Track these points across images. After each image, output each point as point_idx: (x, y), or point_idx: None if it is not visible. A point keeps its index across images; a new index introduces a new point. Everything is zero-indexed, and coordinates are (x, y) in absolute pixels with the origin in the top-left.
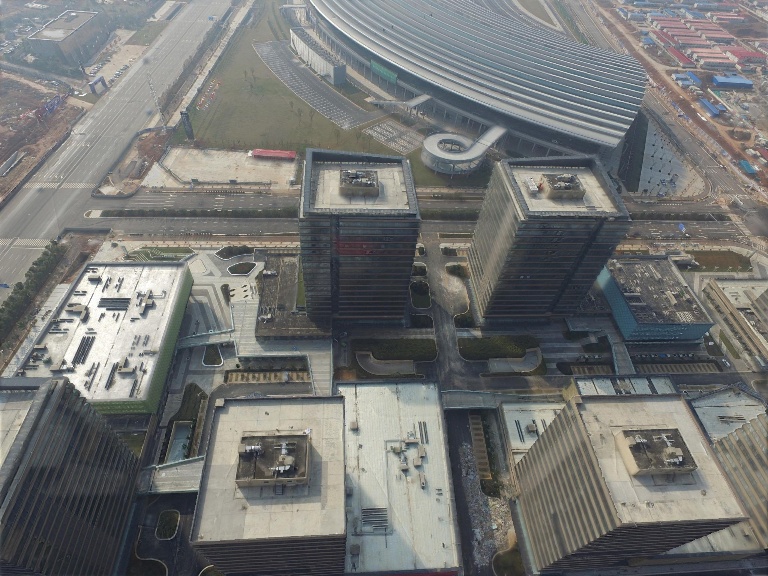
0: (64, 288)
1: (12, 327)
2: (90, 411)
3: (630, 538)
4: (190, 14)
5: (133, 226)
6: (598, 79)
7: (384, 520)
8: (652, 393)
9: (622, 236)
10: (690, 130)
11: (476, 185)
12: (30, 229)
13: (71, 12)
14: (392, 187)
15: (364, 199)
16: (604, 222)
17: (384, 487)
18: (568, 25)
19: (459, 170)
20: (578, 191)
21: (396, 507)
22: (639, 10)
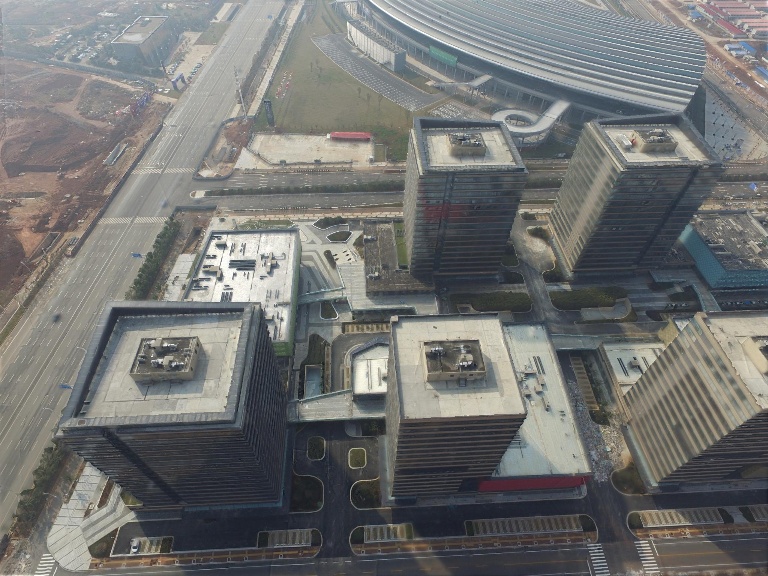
0: (186, 257)
1: (148, 291)
2: None
3: (761, 432)
4: (248, 14)
5: (235, 203)
6: (658, 50)
7: (517, 436)
8: None
9: (714, 184)
10: (749, 97)
11: (545, 156)
12: (146, 209)
13: (144, 17)
14: (495, 147)
15: (473, 158)
16: (698, 170)
17: None
18: (612, 4)
19: (528, 143)
20: (671, 143)
21: (525, 426)
22: None
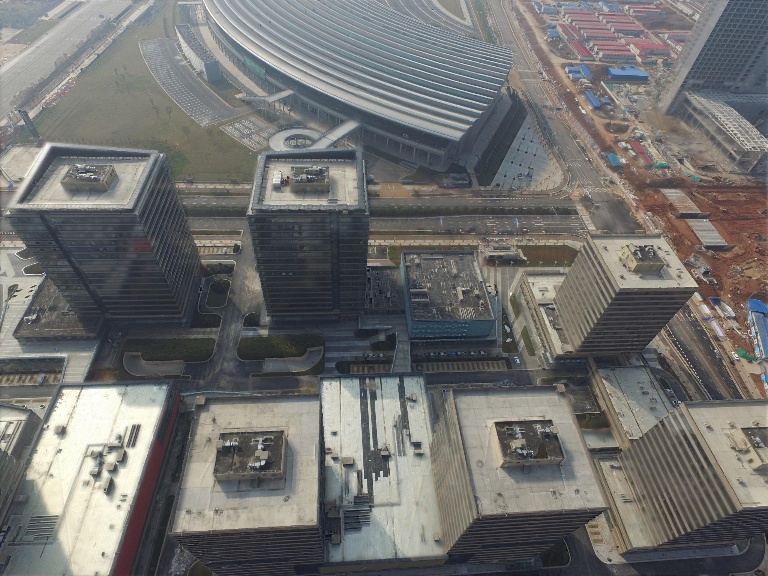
0: None
1: None
2: None
3: (228, 547)
4: (85, 12)
5: None
6: (459, 72)
7: (50, 528)
8: (399, 392)
9: (367, 230)
10: (568, 123)
11: None
12: None
13: None
14: (127, 182)
15: (89, 194)
16: (339, 215)
17: (66, 493)
18: (478, 19)
19: None
20: (320, 184)
21: (70, 514)
22: (556, 4)
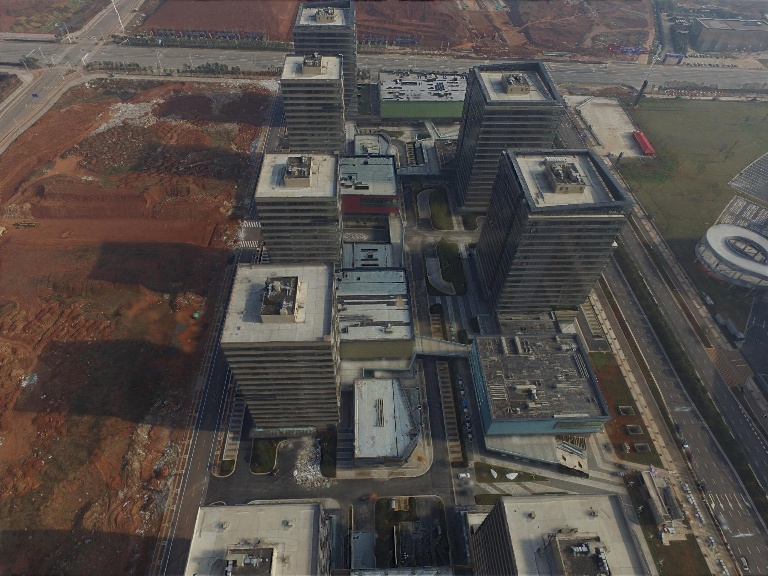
0: None
1: None
2: (355, 59)
3: None
4: None
5: None
6: None
7: None
8: (394, 321)
9: (523, 232)
10: None
11: (696, 283)
12: None
13: (764, 23)
14: (520, 99)
15: (500, 89)
16: None
17: None
18: None
19: (707, 260)
20: (555, 180)
21: None
22: None
